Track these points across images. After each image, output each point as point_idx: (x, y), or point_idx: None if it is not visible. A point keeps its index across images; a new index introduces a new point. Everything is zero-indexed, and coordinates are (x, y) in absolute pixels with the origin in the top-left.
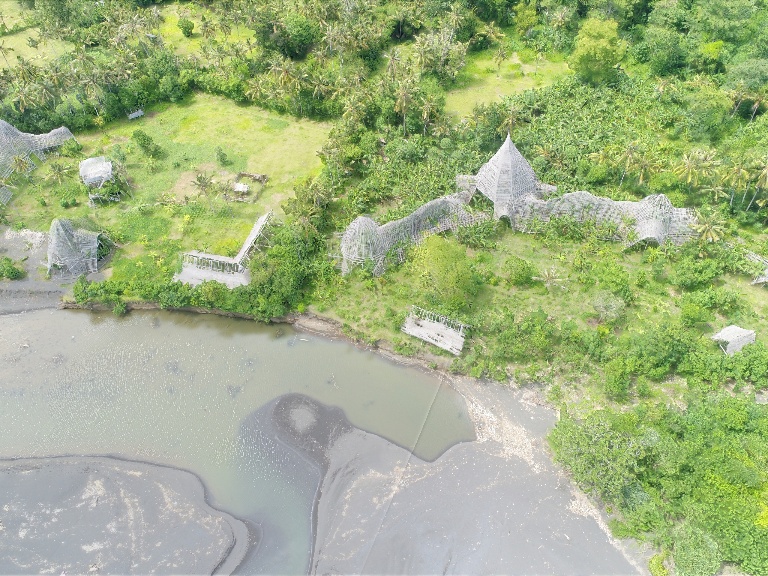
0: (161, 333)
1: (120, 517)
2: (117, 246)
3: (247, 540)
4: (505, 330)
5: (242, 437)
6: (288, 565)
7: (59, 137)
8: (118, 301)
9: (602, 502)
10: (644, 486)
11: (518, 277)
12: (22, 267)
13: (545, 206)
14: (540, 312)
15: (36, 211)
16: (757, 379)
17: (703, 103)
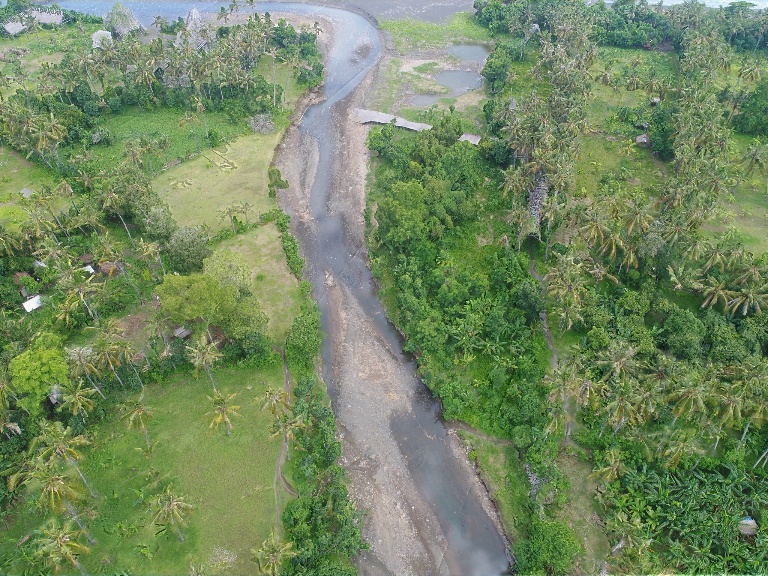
0: None
1: None
2: None
3: None
4: None
5: None
6: None
7: None
8: None
9: None
10: None
11: None
12: None
13: None
14: None
15: None
16: None
17: None
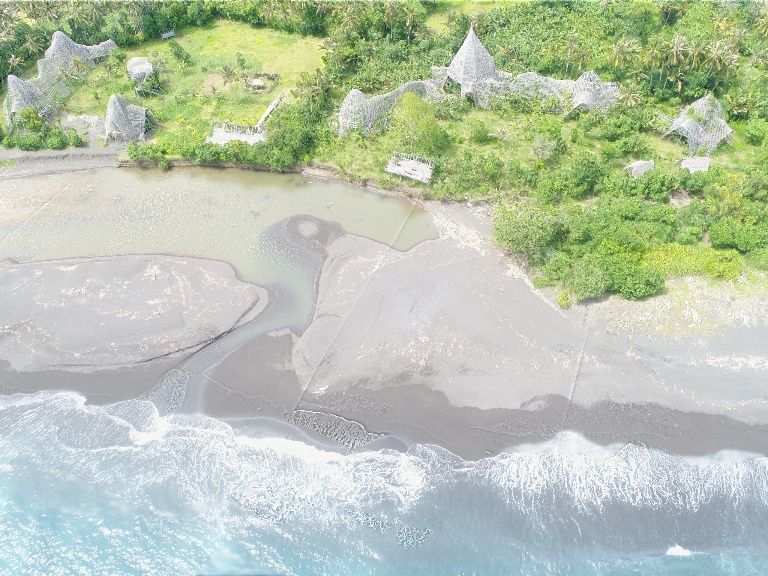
0: (197, 181)
1: (173, 286)
2: (159, 124)
3: (267, 298)
4: (464, 164)
5: (262, 241)
6: (298, 311)
7: (107, 48)
8: (162, 158)
9: (529, 268)
10: (558, 252)
11: (477, 133)
12: (84, 139)
13: (502, 86)
14: (493, 156)
15: (91, 103)
16: (654, 195)
17: (635, 10)
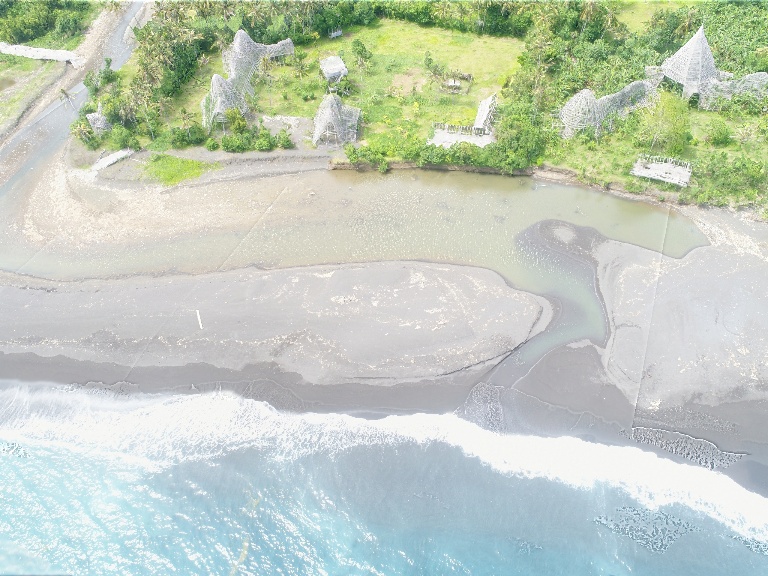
0: (422, 184)
1: (446, 294)
2: (363, 125)
3: (551, 307)
4: None
5: (519, 247)
6: (589, 321)
7: (285, 47)
8: (383, 160)
9: None
10: None
11: (719, 135)
12: None
13: (728, 86)
14: (743, 159)
15: (280, 103)
16: None
17: None
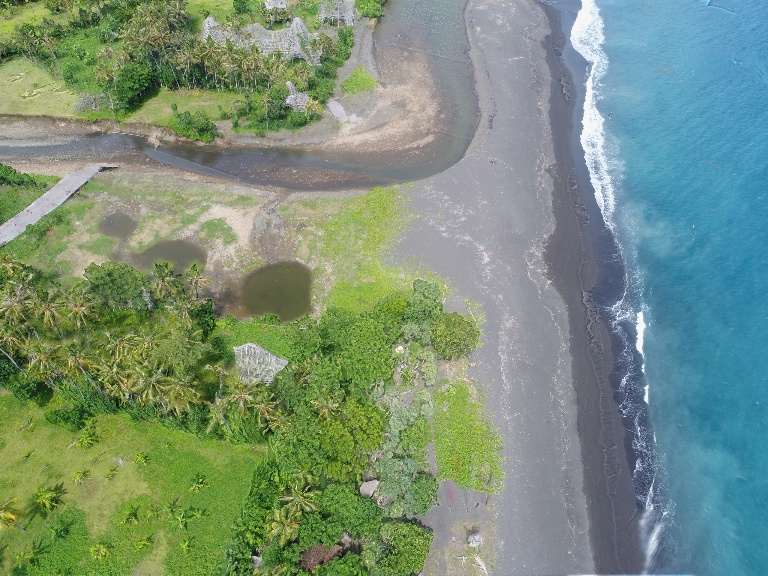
0: (397, 7)
1: None
2: None
3: None
4: None
5: None
6: None
7: None
8: None
9: None
10: None
11: None
12: None
13: None
14: None
15: None
16: None
17: None
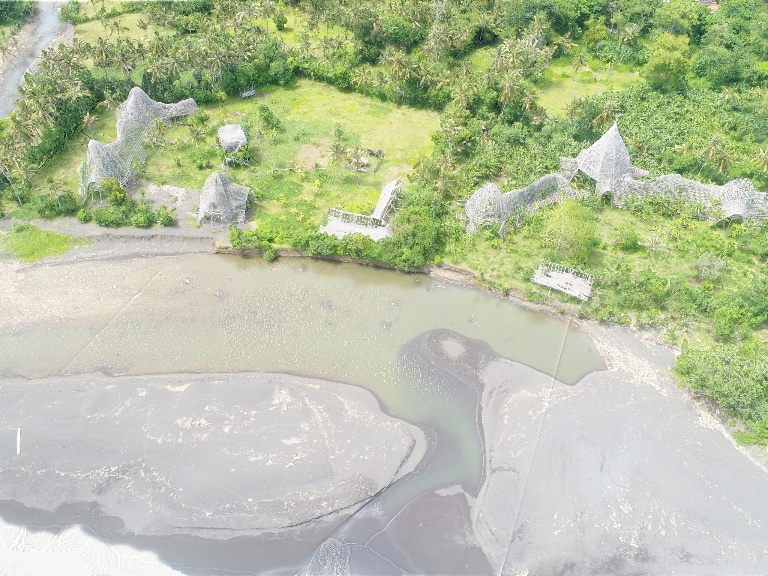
0: (310, 277)
1: (310, 419)
2: (256, 203)
3: (425, 441)
4: None
5: (402, 361)
6: (464, 461)
7: (186, 107)
8: (269, 247)
9: (725, 418)
10: None
11: (627, 241)
12: (172, 216)
13: (641, 186)
14: (649, 270)
15: (172, 170)
16: None
17: (767, 109)
